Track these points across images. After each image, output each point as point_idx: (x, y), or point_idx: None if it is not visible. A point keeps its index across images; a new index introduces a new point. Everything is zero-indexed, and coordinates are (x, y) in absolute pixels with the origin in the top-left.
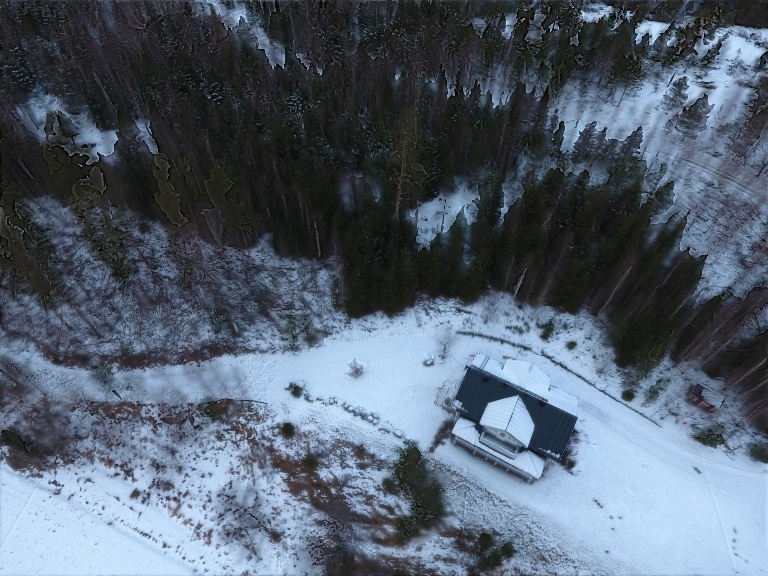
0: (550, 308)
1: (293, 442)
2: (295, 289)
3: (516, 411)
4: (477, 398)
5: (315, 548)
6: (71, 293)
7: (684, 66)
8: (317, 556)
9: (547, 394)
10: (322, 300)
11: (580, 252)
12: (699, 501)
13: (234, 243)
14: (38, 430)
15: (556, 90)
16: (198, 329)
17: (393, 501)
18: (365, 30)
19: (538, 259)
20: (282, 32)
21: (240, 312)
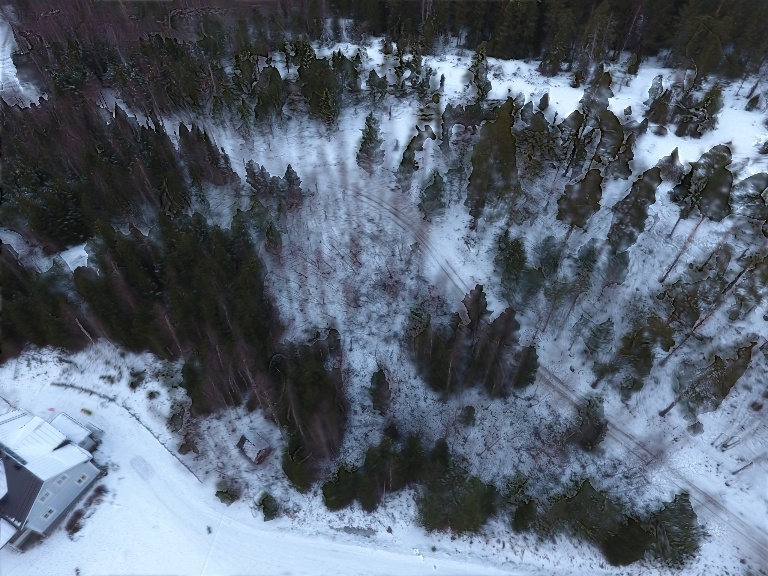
0: (151, 355)
1: None
2: None
3: None
4: None
5: None
6: None
7: (414, 99)
8: None
9: (43, 455)
10: None
11: (167, 297)
12: (187, 566)
13: None
14: None
15: (247, 128)
16: None
17: None
18: (108, 70)
19: (96, 308)
20: (30, 73)
21: None
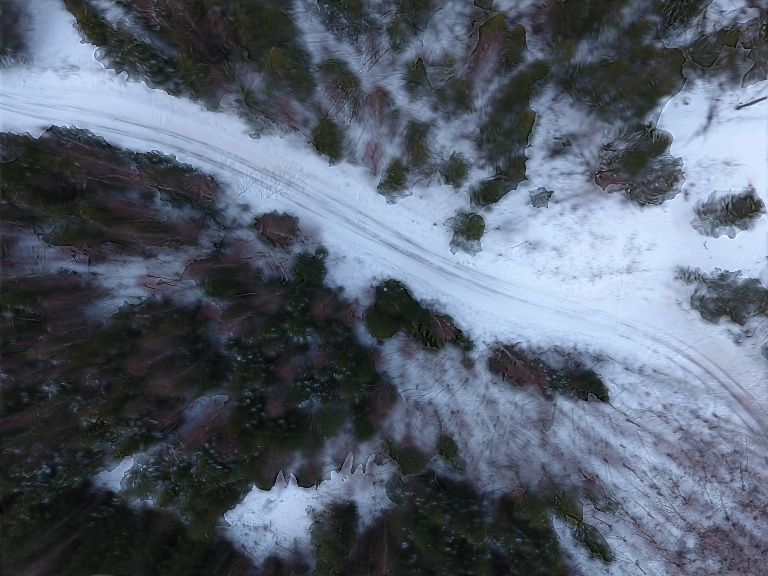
0: None
1: None
2: None
3: None
4: None
5: None
6: None
7: None
8: None
9: None
10: None
11: None
12: None
13: None
14: None
15: (476, 239)
16: None
17: None
18: None
19: None
20: None
21: None
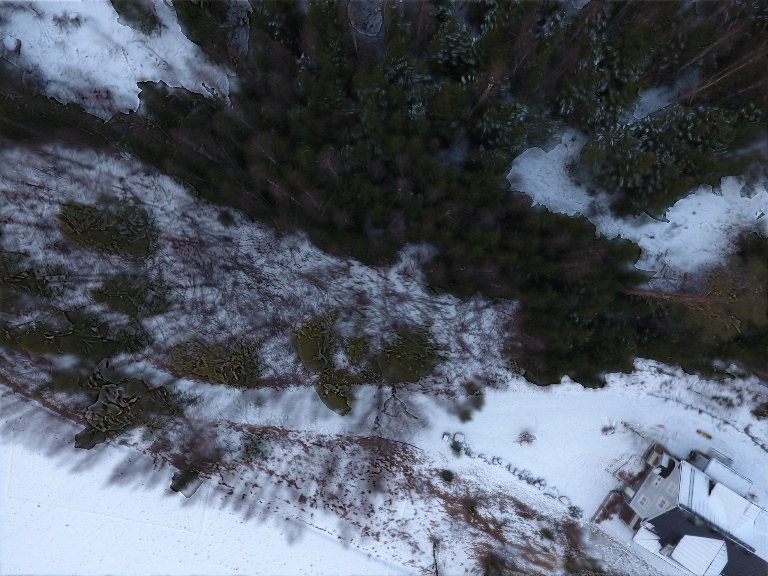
0: None
1: (451, 483)
2: (451, 329)
3: (717, 557)
4: (674, 528)
5: (470, 549)
6: (159, 303)
7: None
8: (471, 554)
9: (753, 533)
10: (486, 343)
11: None
12: None
13: (364, 259)
14: (189, 443)
15: None
16: (331, 357)
17: (549, 544)
18: None
19: None
20: None
21: (380, 344)
